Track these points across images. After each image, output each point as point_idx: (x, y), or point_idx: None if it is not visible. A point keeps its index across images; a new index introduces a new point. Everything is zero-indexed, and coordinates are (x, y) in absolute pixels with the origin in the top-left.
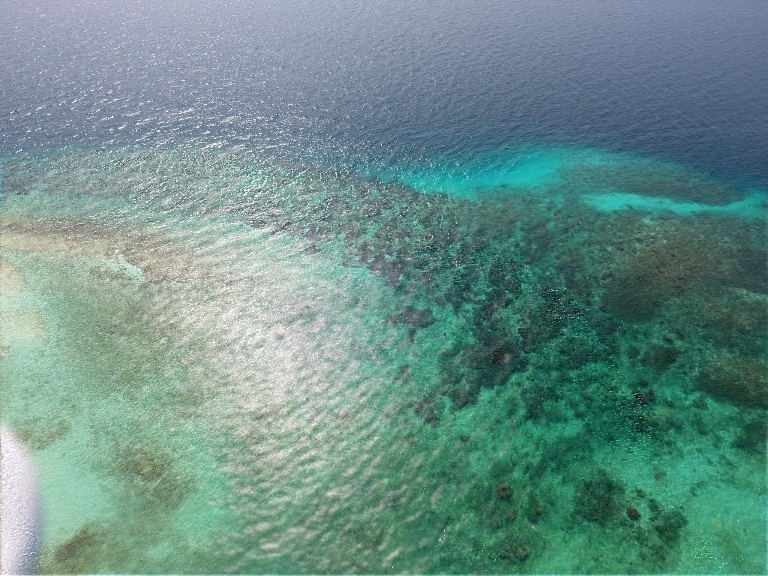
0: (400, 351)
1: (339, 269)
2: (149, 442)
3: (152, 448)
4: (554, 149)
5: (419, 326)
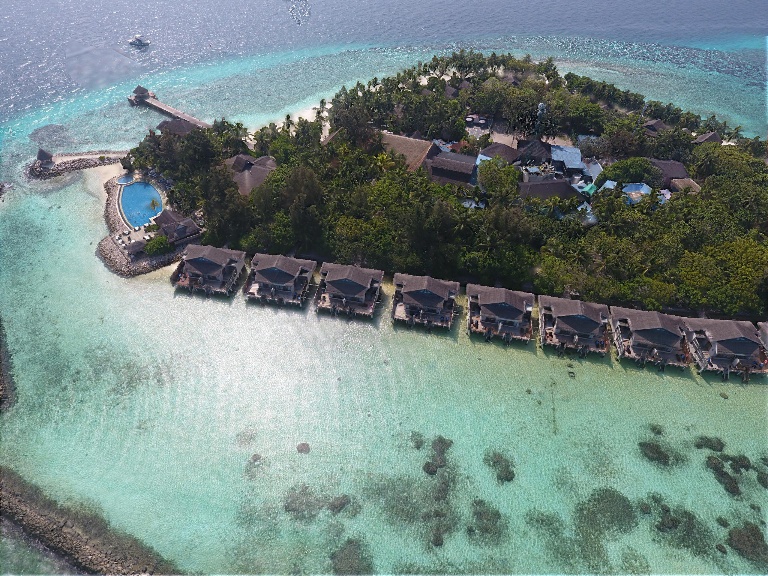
0: (764, 92)
1: (704, 72)
2: (699, 108)
3: (702, 109)
4: (755, 35)
5: (763, 86)
